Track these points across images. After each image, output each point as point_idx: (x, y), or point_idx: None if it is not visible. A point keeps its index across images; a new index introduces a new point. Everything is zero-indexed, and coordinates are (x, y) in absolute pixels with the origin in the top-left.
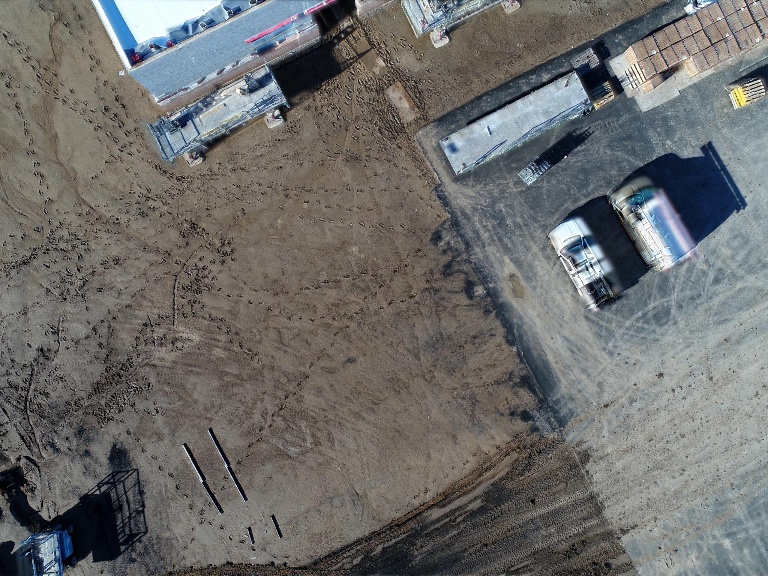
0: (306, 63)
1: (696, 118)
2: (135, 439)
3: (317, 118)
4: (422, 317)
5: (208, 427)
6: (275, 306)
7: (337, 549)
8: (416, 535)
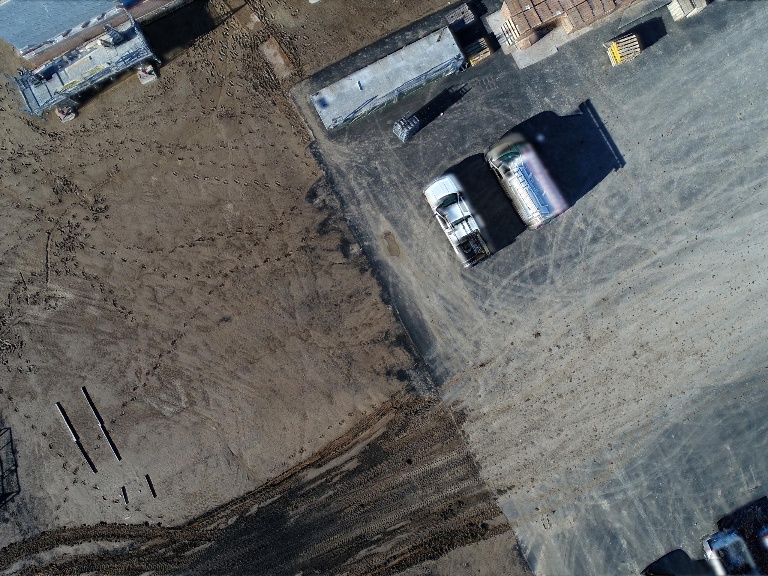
0: (179, 18)
1: (574, 75)
2: (8, 397)
3: (191, 74)
4: (298, 275)
5: (81, 386)
6: (149, 264)
7: (212, 509)
8: (292, 495)
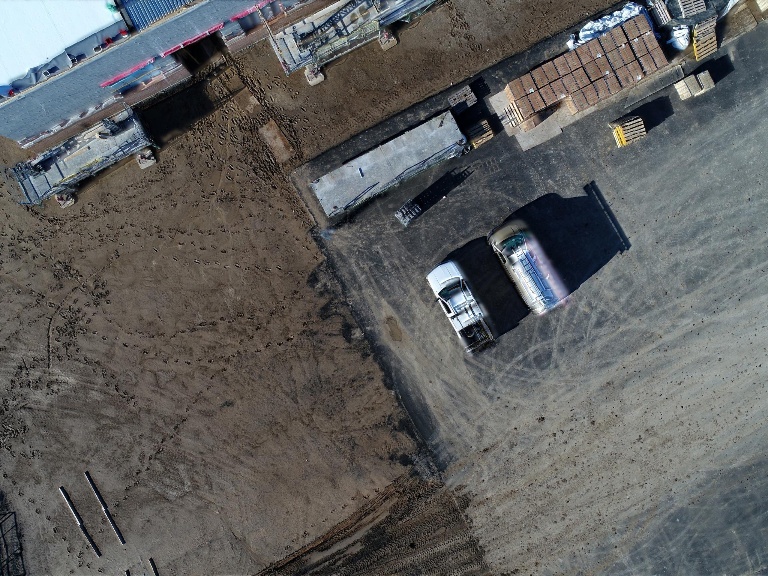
0: (178, 102)
1: (579, 157)
2: (12, 482)
3: (191, 158)
4: (299, 360)
5: (85, 470)
6: (151, 349)
7: None
8: None
